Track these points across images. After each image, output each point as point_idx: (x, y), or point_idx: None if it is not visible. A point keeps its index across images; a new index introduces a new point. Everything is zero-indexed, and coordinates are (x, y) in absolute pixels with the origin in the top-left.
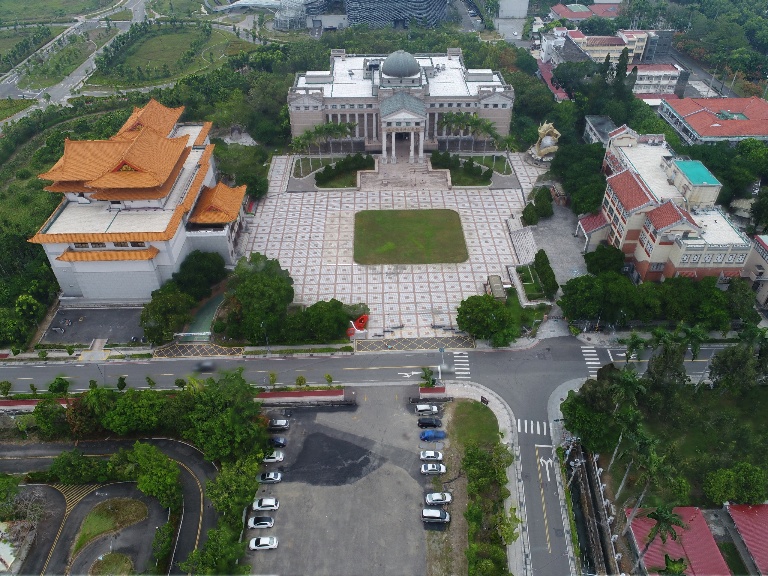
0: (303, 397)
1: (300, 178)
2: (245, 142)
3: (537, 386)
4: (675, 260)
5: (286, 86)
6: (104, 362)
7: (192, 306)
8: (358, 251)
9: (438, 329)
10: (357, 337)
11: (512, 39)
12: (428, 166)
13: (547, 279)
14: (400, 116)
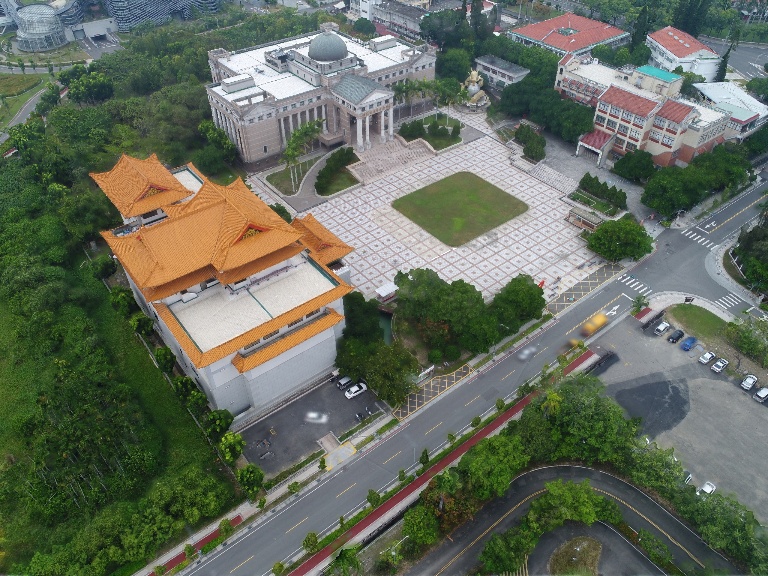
0: (571, 373)
1: (295, 194)
2: None
3: (695, 273)
4: (693, 143)
5: (174, 106)
6: (358, 455)
7: None
8: (441, 236)
9: (583, 268)
10: None
11: (303, 9)
12: (402, 141)
13: (615, 193)
14: (372, 98)
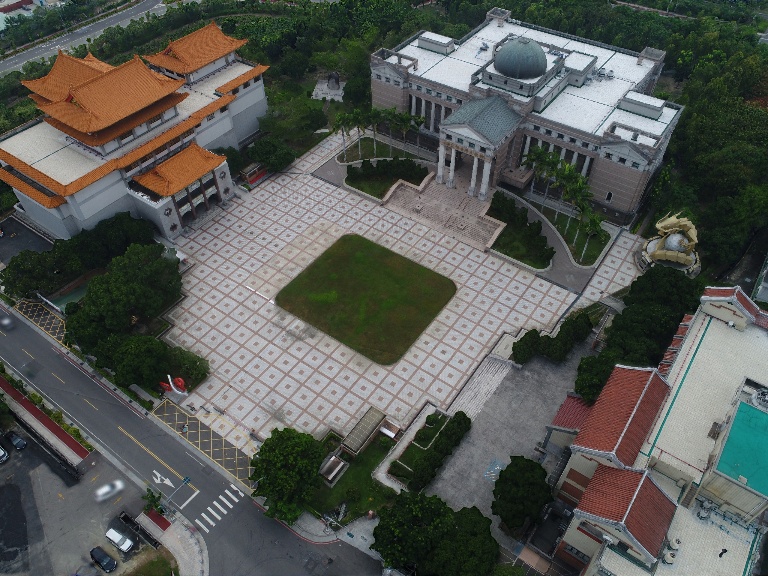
0: (53, 435)
1: (340, 162)
2: (339, 95)
3: None
4: None
5: None
6: None
7: (75, 272)
8: (292, 286)
9: (254, 440)
10: (171, 396)
11: None
12: (483, 208)
13: None
14: (463, 131)
